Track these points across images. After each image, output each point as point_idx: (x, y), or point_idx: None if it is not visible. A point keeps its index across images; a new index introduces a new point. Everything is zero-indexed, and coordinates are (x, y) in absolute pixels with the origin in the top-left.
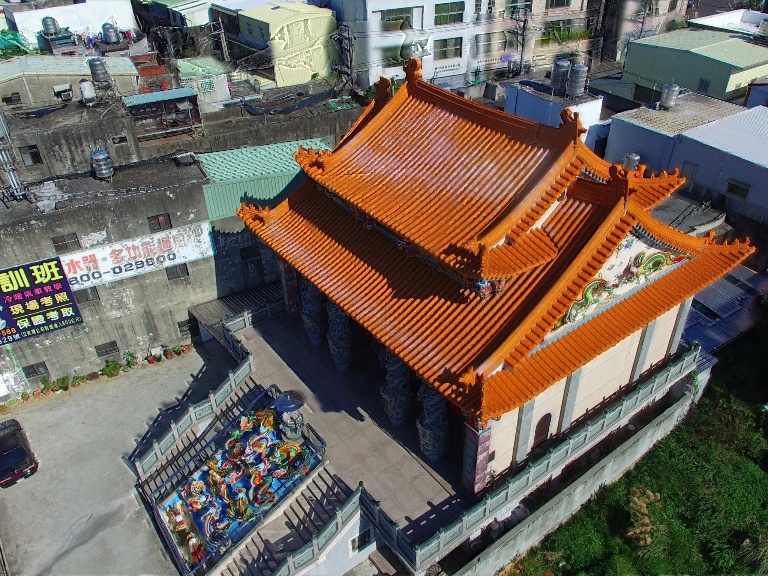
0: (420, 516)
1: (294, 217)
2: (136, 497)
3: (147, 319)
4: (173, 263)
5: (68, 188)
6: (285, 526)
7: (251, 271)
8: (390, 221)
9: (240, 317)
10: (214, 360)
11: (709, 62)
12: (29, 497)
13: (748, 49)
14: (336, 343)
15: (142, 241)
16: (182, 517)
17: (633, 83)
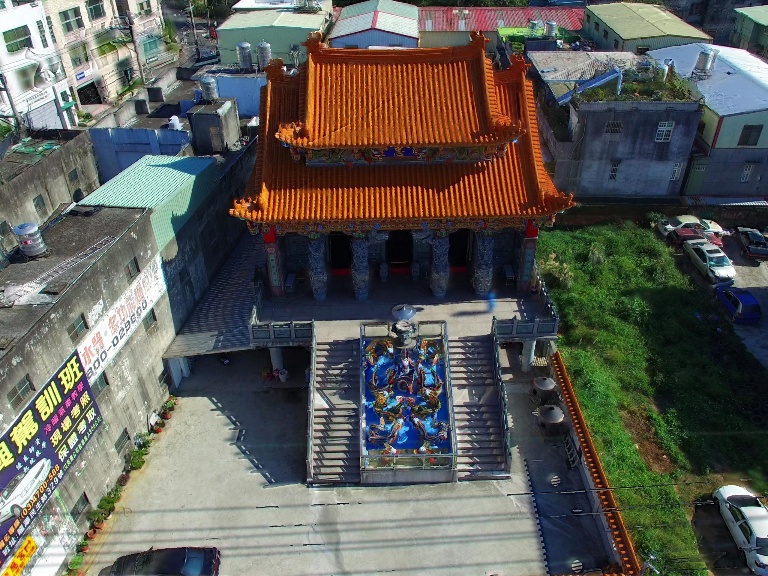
0: (521, 318)
1: (283, 193)
2: (321, 490)
3: (141, 387)
4: (146, 312)
5: (14, 281)
6: (461, 390)
7: (187, 294)
8: (415, 140)
9: (253, 316)
10: (211, 390)
11: (292, 30)
12: (240, 574)
13: (302, 17)
14: (368, 272)
15: (125, 298)
16: (394, 449)
17: (233, 63)
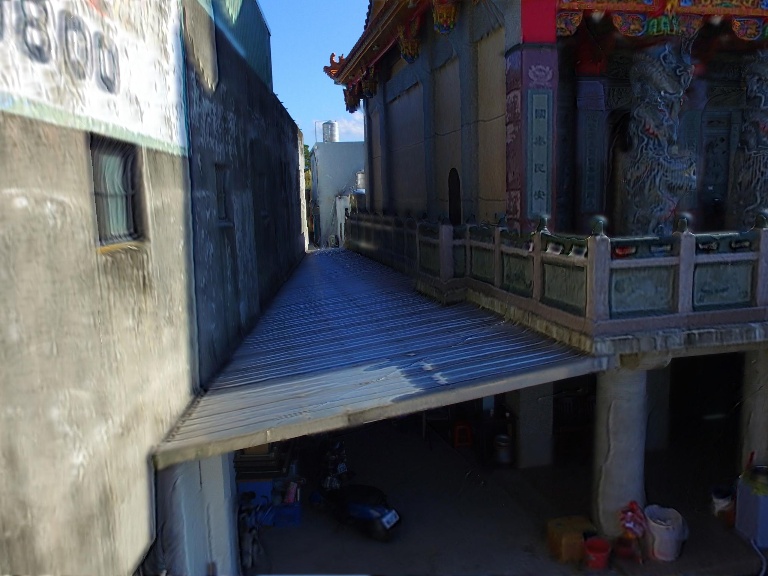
0: None
1: None
2: None
3: None
4: (110, 117)
5: None
6: None
7: (227, 273)
8: None
9: (554, 248)
10: None
11: None
12: None
13: None
14: None
15: None
16: None
17: None
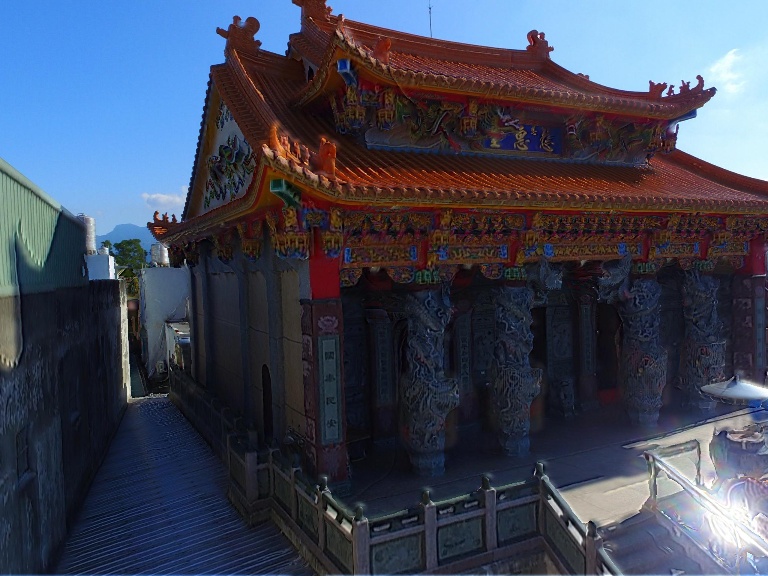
0: None
1: None
2: None
3: None
4: None
5: None
6: None
7: (27, 532)
8: None
9: None
10: None
11: None
12: None
13: None
14: None
15: None
16: None
17: None
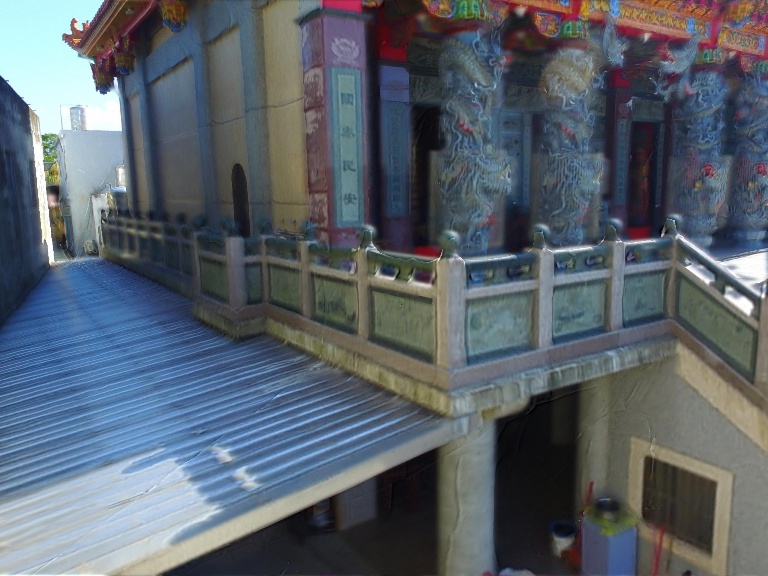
0: None
1: None
2: None
3: None
4: None
5: None
6: None
7: None
8: None
9: (385, 271)
10: None
11: None
12: None
13: None
14: None
15: None
16: None
17: None
